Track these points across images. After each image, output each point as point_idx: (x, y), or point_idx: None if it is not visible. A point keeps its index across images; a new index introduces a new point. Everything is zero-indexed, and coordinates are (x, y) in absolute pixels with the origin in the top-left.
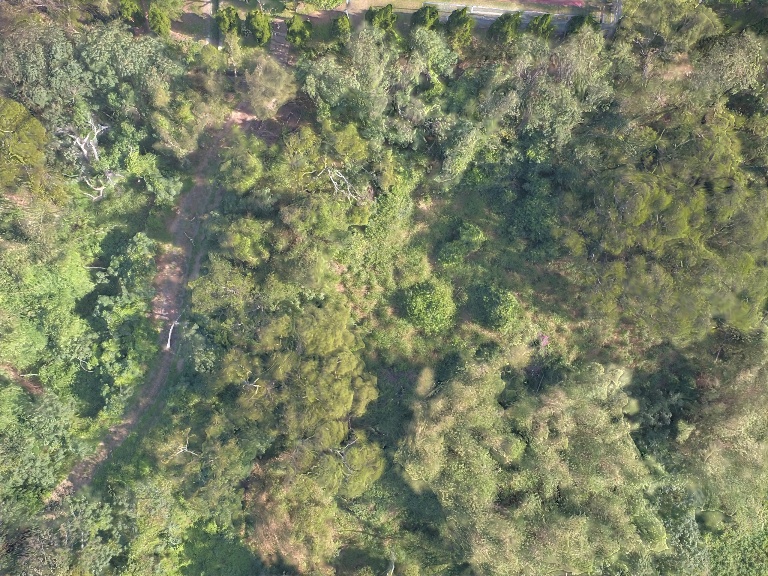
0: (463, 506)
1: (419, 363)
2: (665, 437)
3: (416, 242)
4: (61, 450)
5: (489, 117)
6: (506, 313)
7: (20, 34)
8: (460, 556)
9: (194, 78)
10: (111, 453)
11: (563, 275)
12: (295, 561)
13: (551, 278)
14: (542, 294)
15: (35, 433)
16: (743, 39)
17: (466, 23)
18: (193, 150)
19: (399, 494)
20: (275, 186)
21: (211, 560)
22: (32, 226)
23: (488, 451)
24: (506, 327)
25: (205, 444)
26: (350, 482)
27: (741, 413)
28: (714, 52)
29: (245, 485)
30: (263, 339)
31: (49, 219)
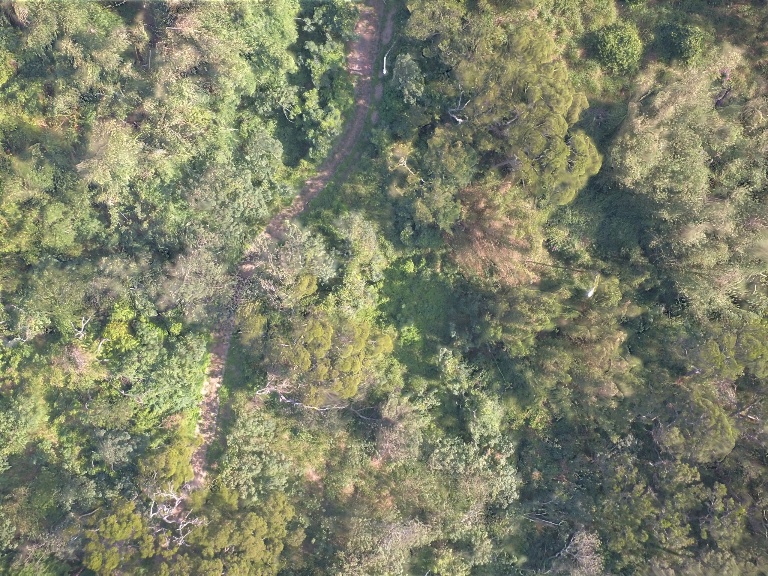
0: (678, 195)
1: (607, 102)
2: None
3: None
4: (269, 190)
5: None
6: (696, 43)
7: None
8: (649, 280)
9: None
10: (308, 203)
11: (741, 17)
12: (490, 293)
13: (731, 19)
14: (722, 35)
15: (251, 167)
16: None
17: None
18: None
19: (594, 219)
20: None
21: (409, 297)
22: None
23: (701, 144)
24: (694, 59)
25: (427, 155)
26: (575, 171)
27: None
28: None
29: (461, 197)
30: (458, 83)
31: None
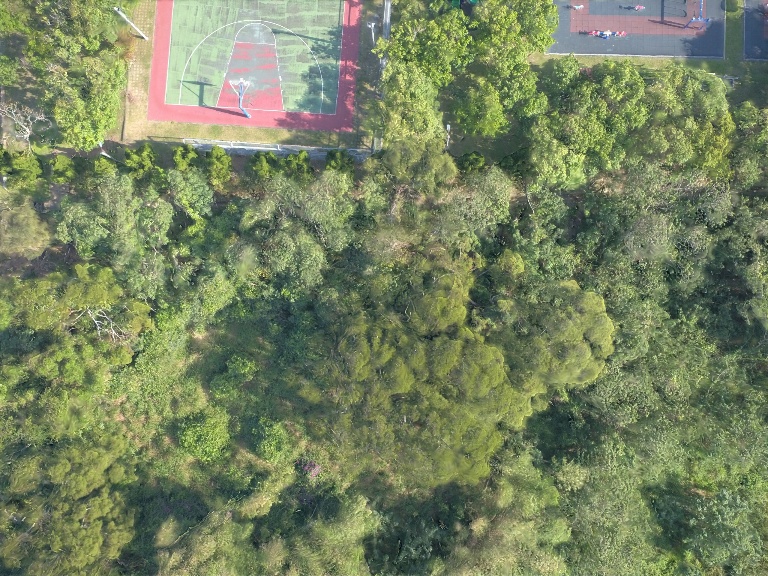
0: None
1: (197, 491)
2: (423, 572)
3: (191, 372)
4: None
5: (234, 262)
6: (269, 448)
7: None
8: None
9: None
10: None
11: (336, 403)
12: None
13: (323, 407)
14: None
15: None
16: (489, 176)
17: (216, 165)
18: None
19: None
20: (36, 329)
21: None
22: None
23: None
24: (273, 459)
25: None
26: None
27: (466, 567)
28: (454, 194)
29: None
30: (48, 468)
31: None
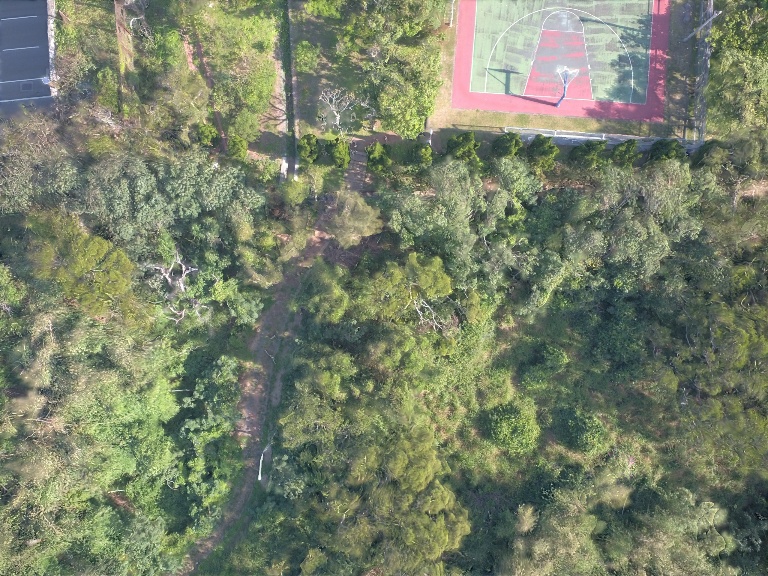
0: None
1: (503, 483)
2: (755, 564)
3: (499, 363)
4: (152, 569)
5: (578, 252)
6: (593, 440)
7: (104, 168)
8: None
9: (271, 197)
10: (197, 565)
11: (647, 395)
12: None
13: (635, 399)
14: (626, 414)
15: (128, 557)
16: None
17: (552, 153)
18: (279, 282)
19: None
20: (362, 319)
21: None
22: (120, 356)
23: None
24: (592, 451)
25: None
26: None
27: None
28: None
29: None
30: None
31: (138, 353)
